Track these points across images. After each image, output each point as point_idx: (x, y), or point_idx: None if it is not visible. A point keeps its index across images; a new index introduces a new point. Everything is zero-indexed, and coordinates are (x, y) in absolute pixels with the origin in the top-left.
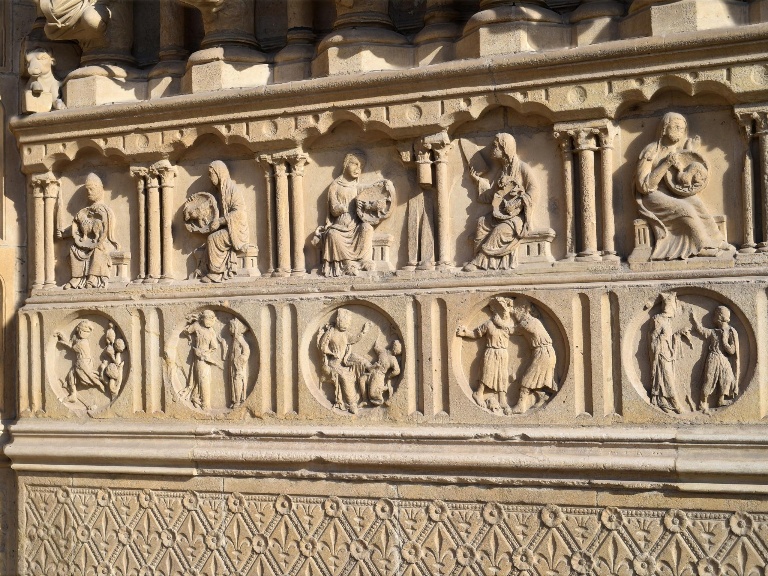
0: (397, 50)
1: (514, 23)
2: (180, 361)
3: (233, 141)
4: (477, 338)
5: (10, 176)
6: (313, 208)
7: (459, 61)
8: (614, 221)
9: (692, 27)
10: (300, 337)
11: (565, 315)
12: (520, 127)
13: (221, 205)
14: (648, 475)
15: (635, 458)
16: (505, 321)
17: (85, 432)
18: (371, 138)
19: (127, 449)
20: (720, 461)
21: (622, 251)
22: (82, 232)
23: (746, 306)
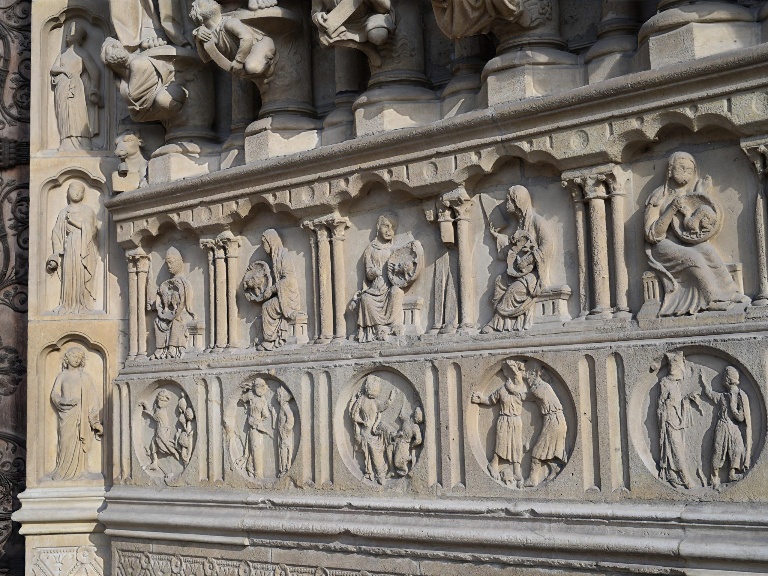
0: (422, 106)
1: (519, 69)
2: (238, 430)
3: (280, 209)
4: (492, 405)
5: (114, 253)
6: (353, 273)
7: (466, 113)
8: (627, 274)
9: (690, 56)
10: (334, 405)
11: (572, 379)
12: (536, 178)
13: (273, 273)
14: (655, 558)
15: (640, 539)
16: (517, 386)
17: (160, 499)
18: (401, 198)
19: (191, 517)
20: (726, 545)
21: (636, 307)
22: (164, 304)
23: (753, 366)
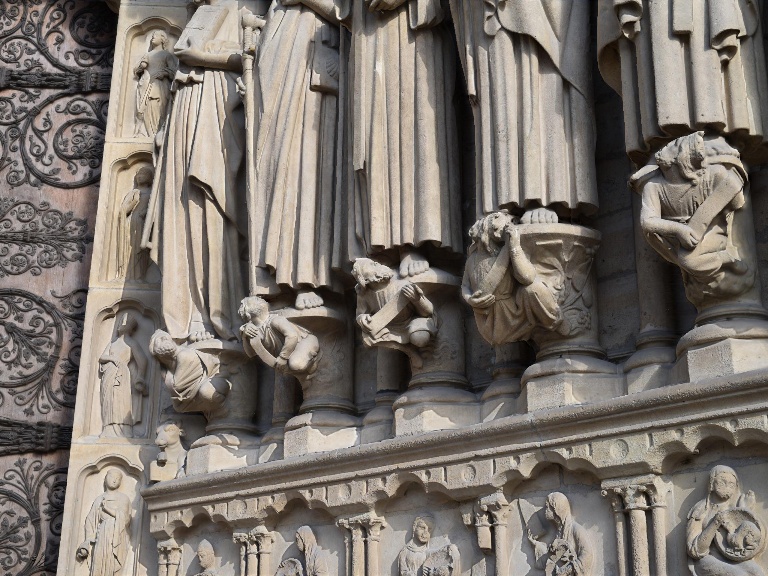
0: (462, 409)
1: (558, 376)
2: None
3: (315, 506)
4: None
5: (146, 543)
6: (387, 575)
7: (505, 418)
8: None
9: (728, 371)
10: None
11: None
12: (575, 485)
13: (305, 572)
14: None
15: None
16: None
17: None
18: (439, 500)
19: None
20: None
21: None
22: None
23: None
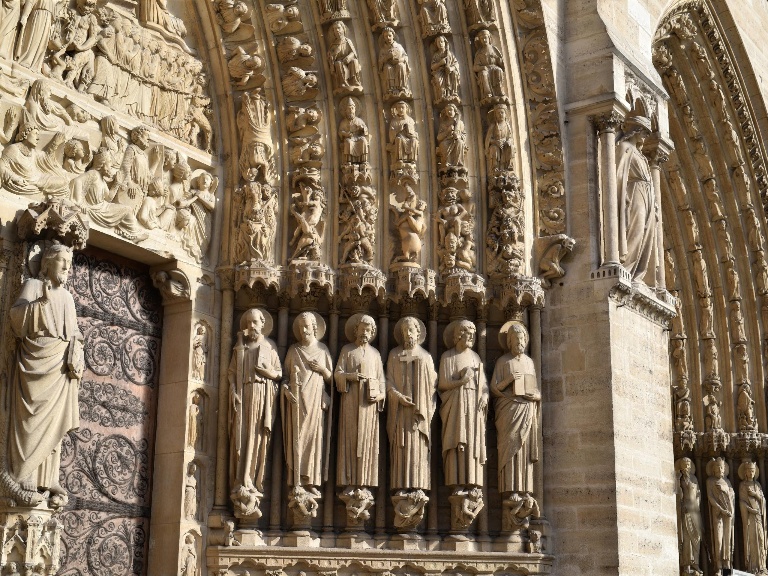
0: (371, 541)
1: (415, 540)
2: None
3: (312, 566)
4: None
5: (203, 567)
6: None
7: (399, 550)
8: None
9: (467, 550)
10: None
11: None
12: (411, 572)
13: None
14: None
15: None
16: None
17: None
18: (360, 570)
19: None
20: None
21: None
22: None
23: None
